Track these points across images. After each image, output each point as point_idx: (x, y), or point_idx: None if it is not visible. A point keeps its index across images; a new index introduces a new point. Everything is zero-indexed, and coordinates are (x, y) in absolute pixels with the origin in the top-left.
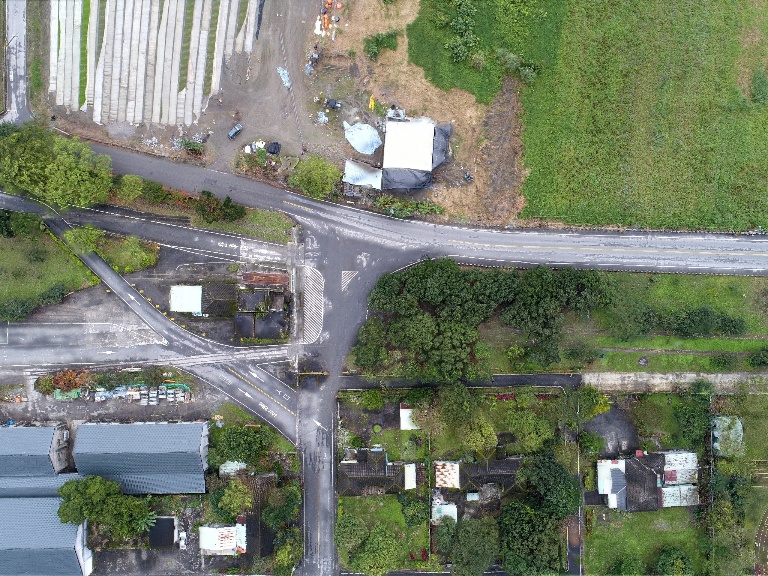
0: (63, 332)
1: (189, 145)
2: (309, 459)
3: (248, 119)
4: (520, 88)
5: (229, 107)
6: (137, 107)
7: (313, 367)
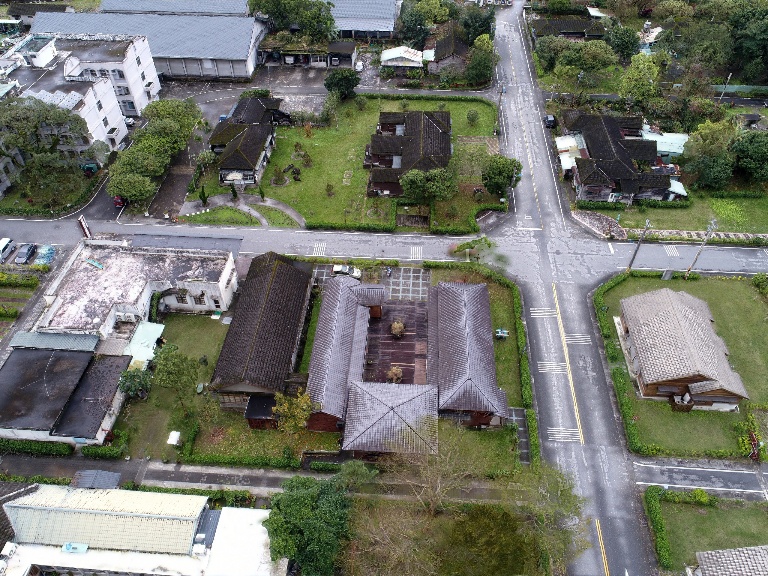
0: None
1: None
2: (498, 37)
3: None
4: None
5: None
6: None
7: None
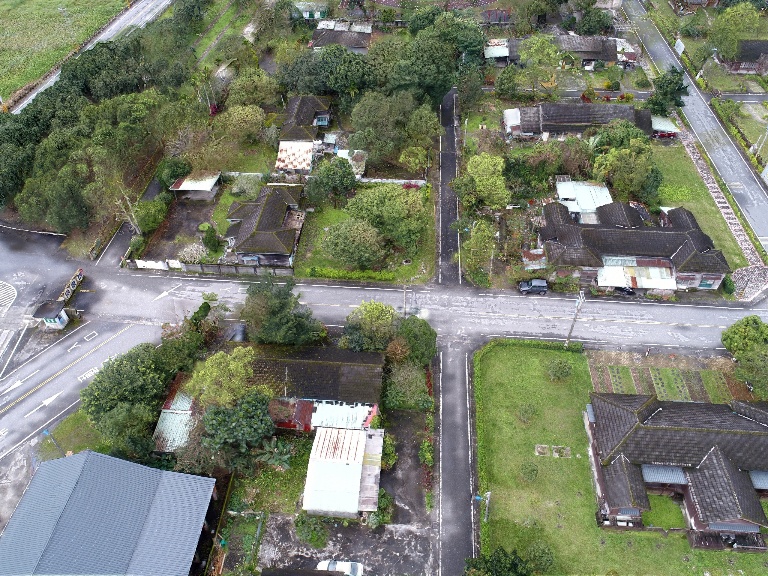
0: None
1: None
2: None
3: None
4: None
5: None
6: None
7: None
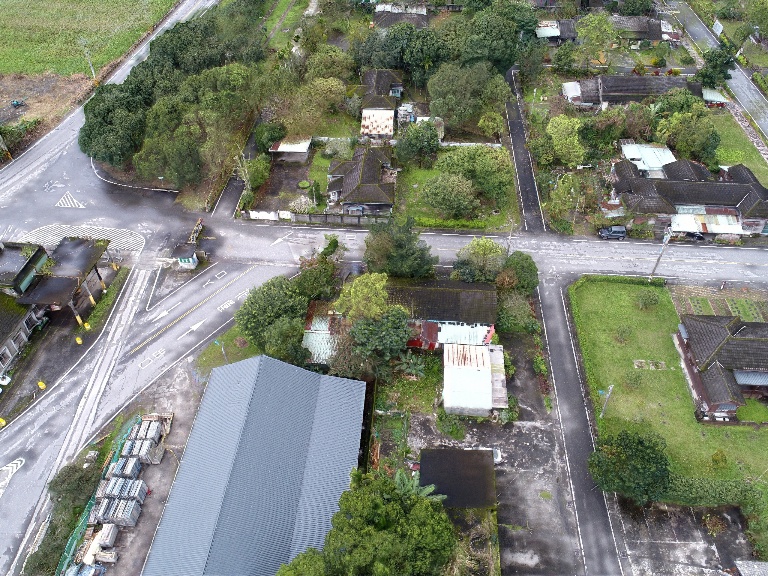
0: None
1: None
2: None
3: None
4: None
5: None
6: None
7: (185, 242)
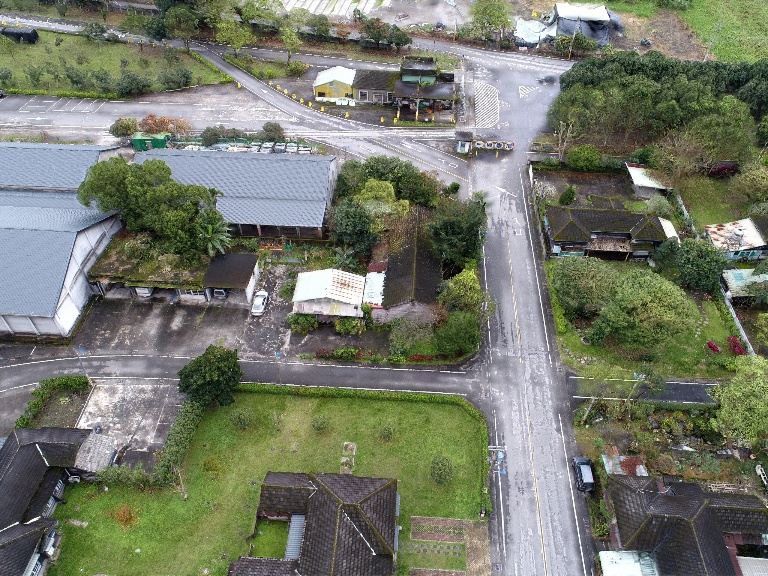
0: (170, 108)
1: (359, 10)
2: (490, 223)
3: (415, 16)
4: (676, 11)
5: (397, 11)
6: (311, 8)
7: None
